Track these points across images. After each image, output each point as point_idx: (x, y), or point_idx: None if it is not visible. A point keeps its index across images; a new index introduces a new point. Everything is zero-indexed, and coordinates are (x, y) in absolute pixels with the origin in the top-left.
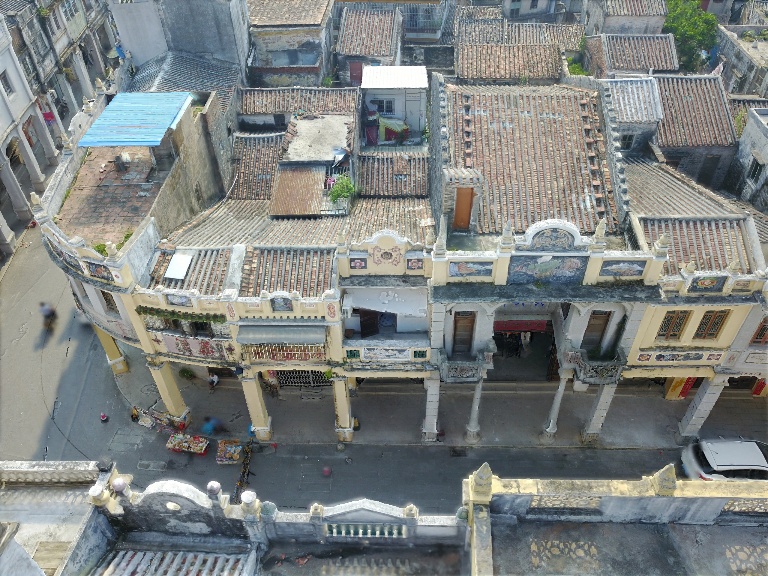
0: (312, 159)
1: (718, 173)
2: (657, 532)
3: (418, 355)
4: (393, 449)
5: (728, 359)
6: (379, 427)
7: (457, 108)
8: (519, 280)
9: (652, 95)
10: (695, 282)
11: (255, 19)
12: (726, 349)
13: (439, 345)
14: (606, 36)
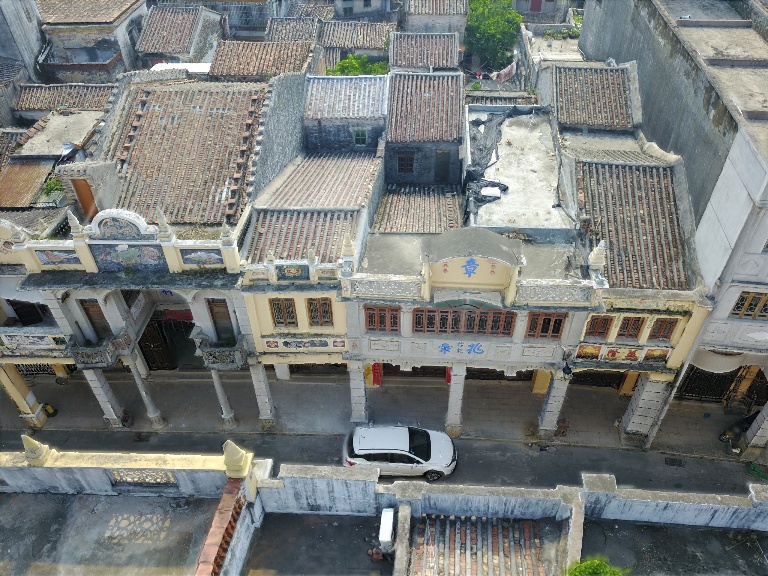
0: (41, 153)
1: (453, 168)
2: (62, 502)
3: (60, 342)
4: (80, 435)
5: (352, 346)
6: (75, 413)
7: (134, 103)
8: (110, 268)
9: (382, 92)
10: (281, 270)
11: (52, 17)
12: (344, 336)
13: (69, 332)
14: (394, 34)
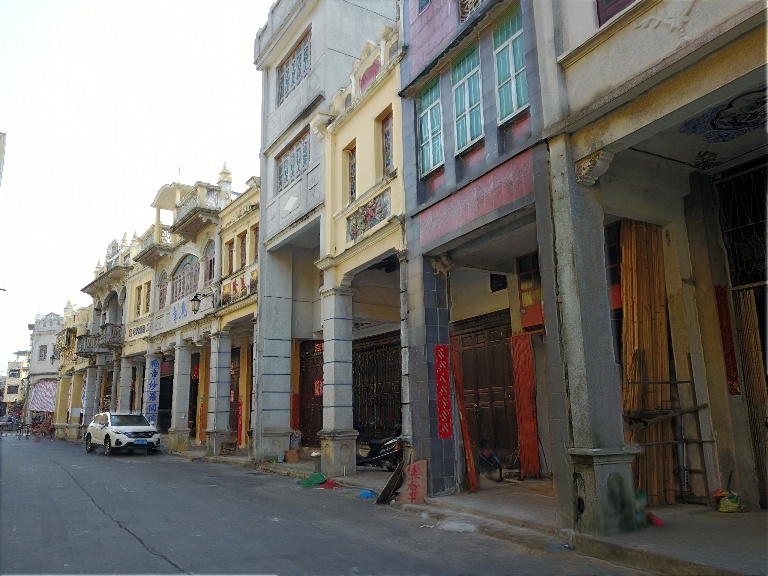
0: None
1: None
2: None
3: None
4: None
5: None
6: None
7: None
8: None
9: None
10: None
11: None
12: None
13: None
14: None
